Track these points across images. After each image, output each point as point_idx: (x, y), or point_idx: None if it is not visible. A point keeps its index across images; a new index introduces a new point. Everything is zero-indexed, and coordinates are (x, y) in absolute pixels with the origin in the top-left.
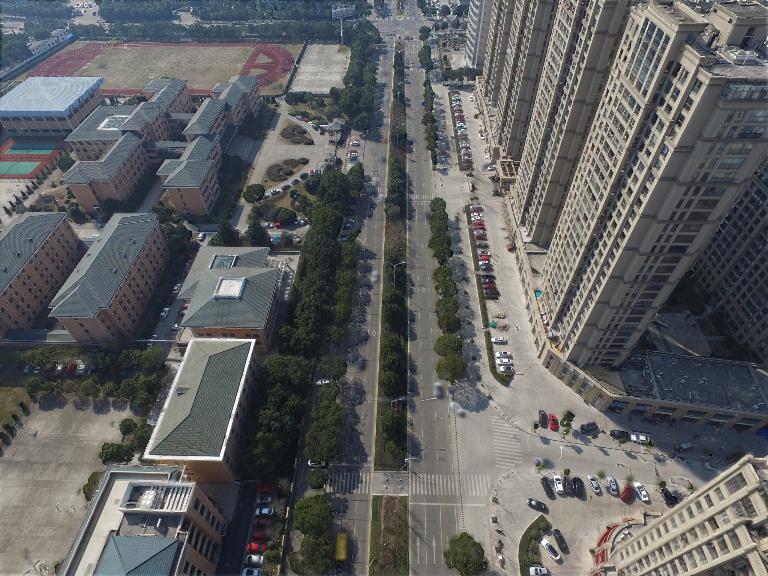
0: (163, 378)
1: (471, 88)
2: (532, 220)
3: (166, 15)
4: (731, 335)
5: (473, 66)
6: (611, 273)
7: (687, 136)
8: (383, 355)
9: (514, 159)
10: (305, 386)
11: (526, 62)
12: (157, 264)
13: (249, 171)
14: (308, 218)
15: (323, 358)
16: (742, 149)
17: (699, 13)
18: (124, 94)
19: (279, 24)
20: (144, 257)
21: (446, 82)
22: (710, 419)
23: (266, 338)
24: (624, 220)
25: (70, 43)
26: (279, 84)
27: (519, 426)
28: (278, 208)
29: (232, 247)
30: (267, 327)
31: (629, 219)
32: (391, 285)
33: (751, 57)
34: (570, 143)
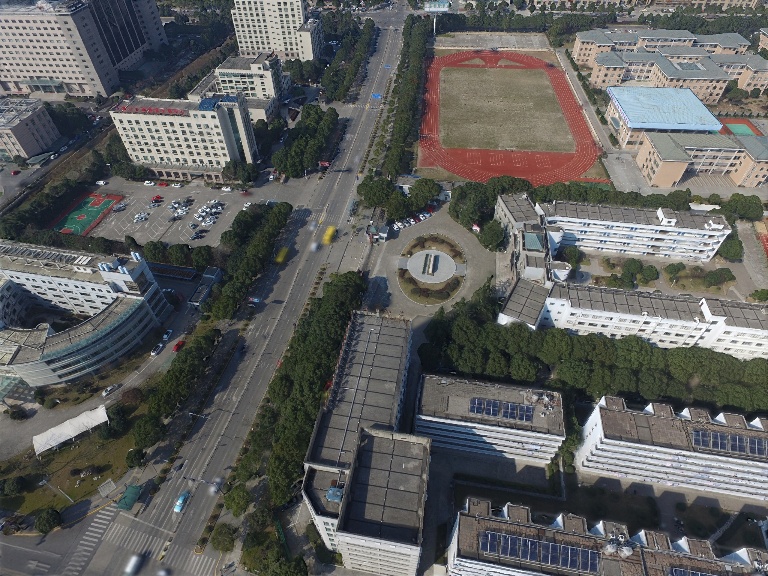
0: None
1: None
2: None
3: None
4: None
5: None
6: None
7: None
8: None
9: None
10: None
11: None
12: None
13: None
14: None
15: None
16: None
17: None
18: None
19: None
20: None
21: None
22: None
23: None
24: None
25: None
26: None
27: None
28: None
29: None
30: None
31: None
32: None
33: None
34: None
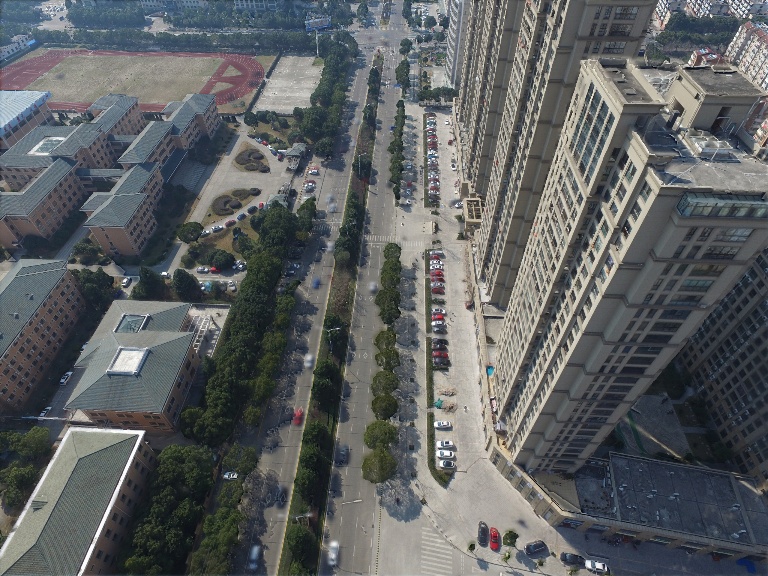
0: (42, 469)
1: (449, 109)
2: (491, 279)
3: (137, 21)
4: (713, 429)
5: (452, 85)
6: (554, 387)
7: (635, 252)
8: (304, 443)
9: (483, 197)
10: (203, 487)
11: (492, 95)
12: (66, 318)
13: (193, 203)
14: (247, 263)
15: (231, 448)
16: (709, 270)
17: (667, 70)
18: (76, 109)
19: (252, 34)
20: (45, 313)
21: (423, 102)
22: (681, 544)
23: (170, 419)
24: (567, 330)
25: (32, 50)
26: (241, 102)
27: (454, 542)
28: (214, 250)
29: (149, 302)
30: (172, 405)
31: (572, 330)
32: (328, 349)
33: (723, 150)
34: (527, 202)
